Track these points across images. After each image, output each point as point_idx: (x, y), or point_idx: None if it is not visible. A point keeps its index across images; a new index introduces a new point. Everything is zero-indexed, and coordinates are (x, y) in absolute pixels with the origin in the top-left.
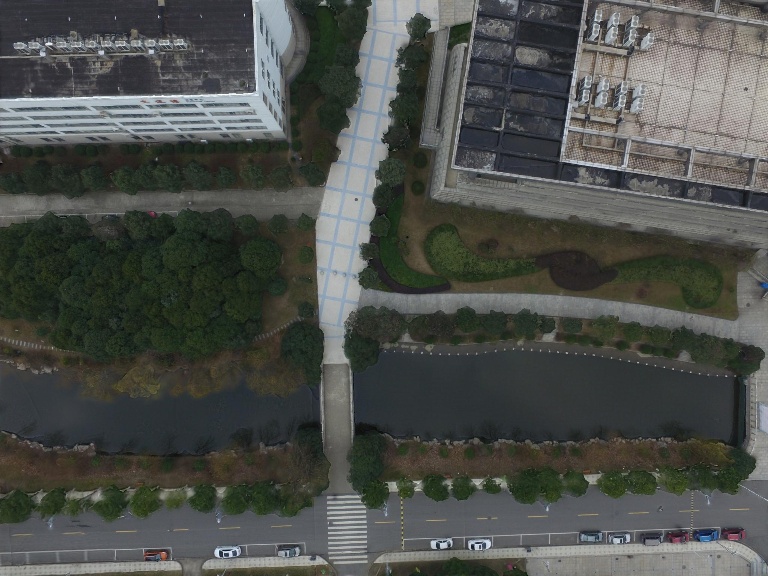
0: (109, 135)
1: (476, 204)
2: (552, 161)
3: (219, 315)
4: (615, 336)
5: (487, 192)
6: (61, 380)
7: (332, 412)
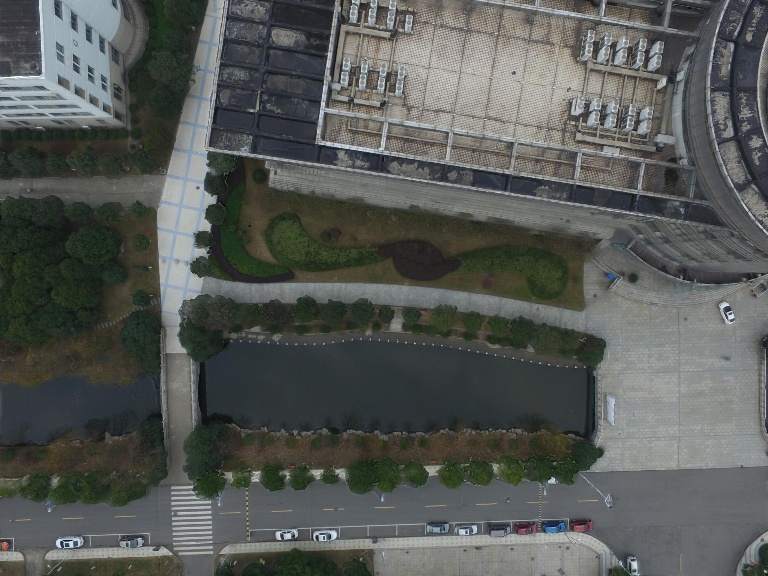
0: None
1: (315, 193)
2: (309, 143)
3: (47, 303)
4: (461, 326)
5: None
6: None
7: (175, 402)
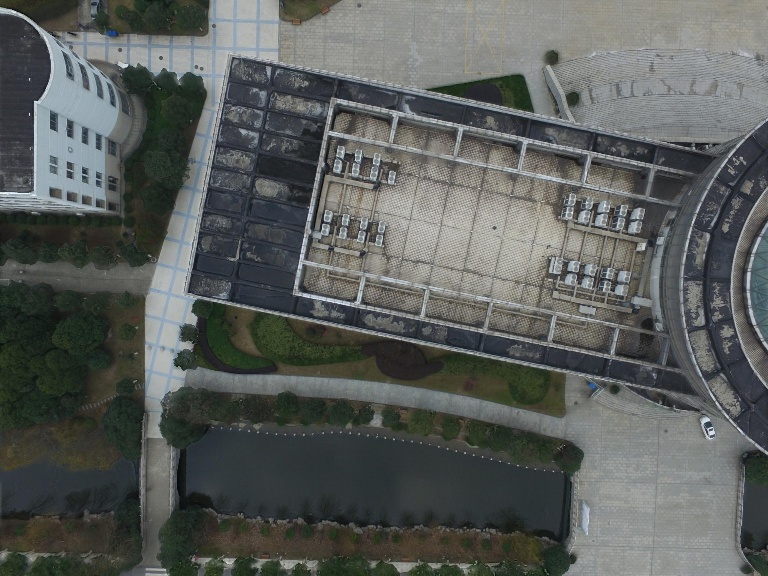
0: None
1: None
2: (287, 293)
3: (31, 390)
4: None
5: None
6: None
7: (154, 486)
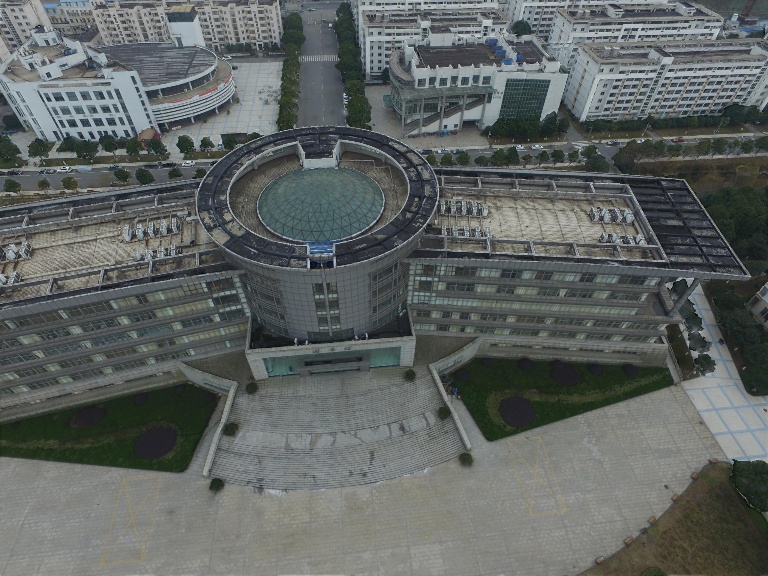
0: None
1: None
2: None
3: None
4: None
5: None
6: None
7: None
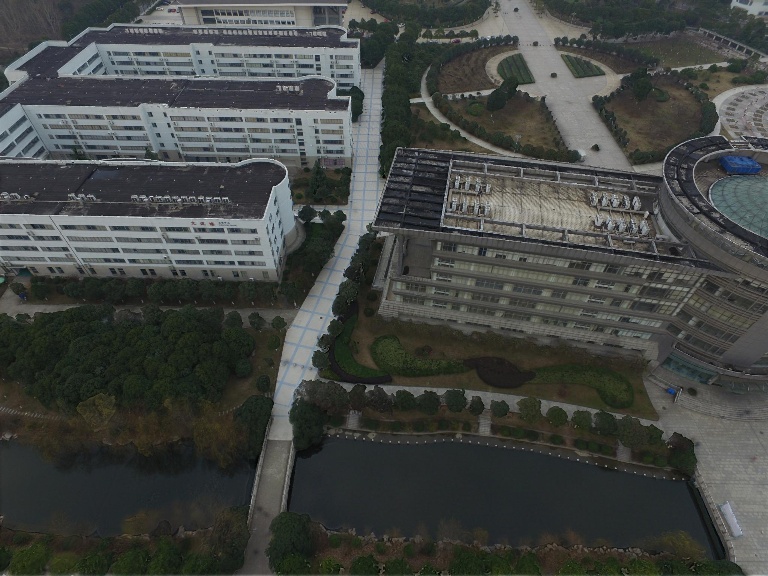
0: (157, 268)
1: (412, 320)
2: (436, 227)
3: (188, 374)
4: (547, 430)
5: (416, 301)
6: (11, 453)
7: (266, 488)
